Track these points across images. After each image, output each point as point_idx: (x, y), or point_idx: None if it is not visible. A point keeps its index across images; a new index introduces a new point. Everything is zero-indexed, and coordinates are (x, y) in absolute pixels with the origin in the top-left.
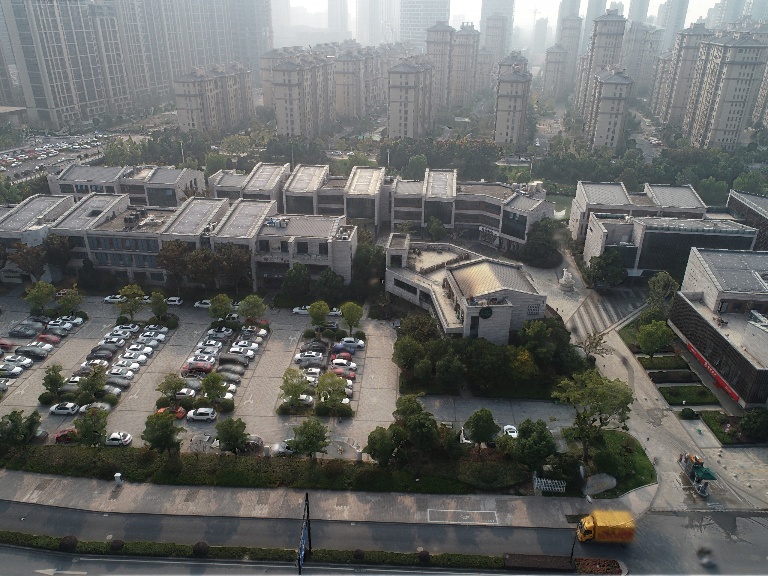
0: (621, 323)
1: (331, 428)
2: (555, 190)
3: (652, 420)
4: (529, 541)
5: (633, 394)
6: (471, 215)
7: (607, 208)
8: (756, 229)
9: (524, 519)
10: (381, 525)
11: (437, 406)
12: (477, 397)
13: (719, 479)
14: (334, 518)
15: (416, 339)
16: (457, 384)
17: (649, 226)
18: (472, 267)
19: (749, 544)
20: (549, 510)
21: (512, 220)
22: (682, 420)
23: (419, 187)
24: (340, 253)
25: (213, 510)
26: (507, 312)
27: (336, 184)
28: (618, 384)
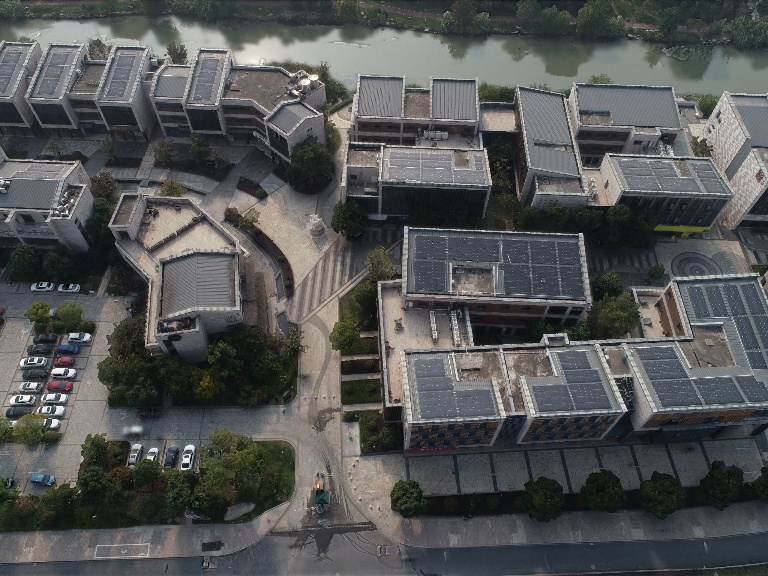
0: (348, 286)
1: (37, 457)
2: (384, 20)
3: (318, 425)
4: (166, 572)
5: (316, 391)
6: (243, 119)
7: (377, 121)
8: (490, 184)
9: (169, 550)
10: (56, 564)
11: (137, 421)
12: (176, 406)
13: (341, 493)
14: (20, 561)
15: (123, 351)
16: (152, 403)
17: (385, 181)
18: (183, 262)
19: (330, 561)
20: (192, 539)
21: (276, 138)
22: (344, 423)
23: (182, 85)
24: (65, 228)
25: None
26: (196, 334)
27: (92, 78)
28: (237, 458)
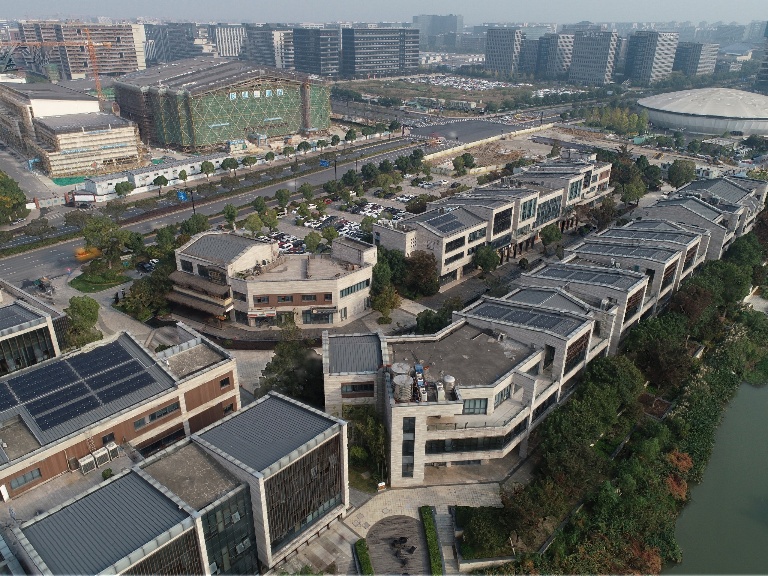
0: None
1: None
2: None
3: None
4: None
5: None
6: None
7: None
8: None
9: None
10: None
11: None
12: None
13: None
14: None
15: None
16: None
17: (119, 334)
18: None
19: None
20: None
21: None
22: None
23: None
24: None
25: (245, 215)
26: None
27: None
28: (90, 221)
